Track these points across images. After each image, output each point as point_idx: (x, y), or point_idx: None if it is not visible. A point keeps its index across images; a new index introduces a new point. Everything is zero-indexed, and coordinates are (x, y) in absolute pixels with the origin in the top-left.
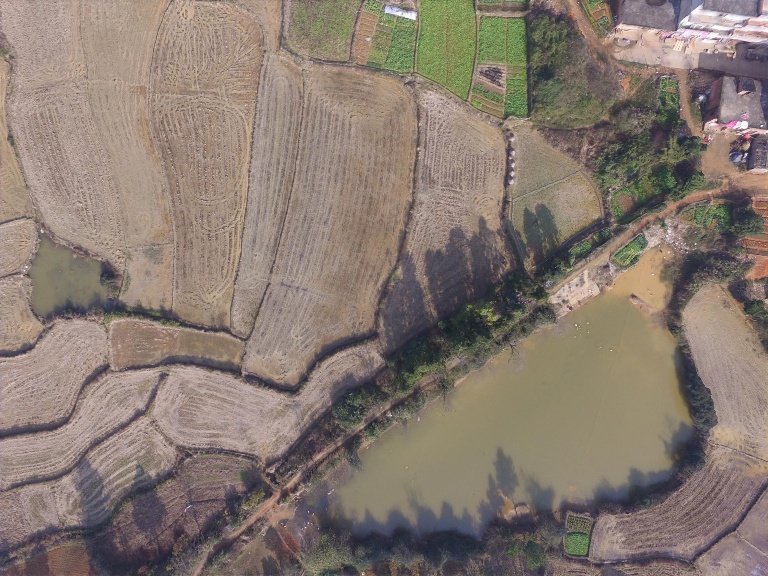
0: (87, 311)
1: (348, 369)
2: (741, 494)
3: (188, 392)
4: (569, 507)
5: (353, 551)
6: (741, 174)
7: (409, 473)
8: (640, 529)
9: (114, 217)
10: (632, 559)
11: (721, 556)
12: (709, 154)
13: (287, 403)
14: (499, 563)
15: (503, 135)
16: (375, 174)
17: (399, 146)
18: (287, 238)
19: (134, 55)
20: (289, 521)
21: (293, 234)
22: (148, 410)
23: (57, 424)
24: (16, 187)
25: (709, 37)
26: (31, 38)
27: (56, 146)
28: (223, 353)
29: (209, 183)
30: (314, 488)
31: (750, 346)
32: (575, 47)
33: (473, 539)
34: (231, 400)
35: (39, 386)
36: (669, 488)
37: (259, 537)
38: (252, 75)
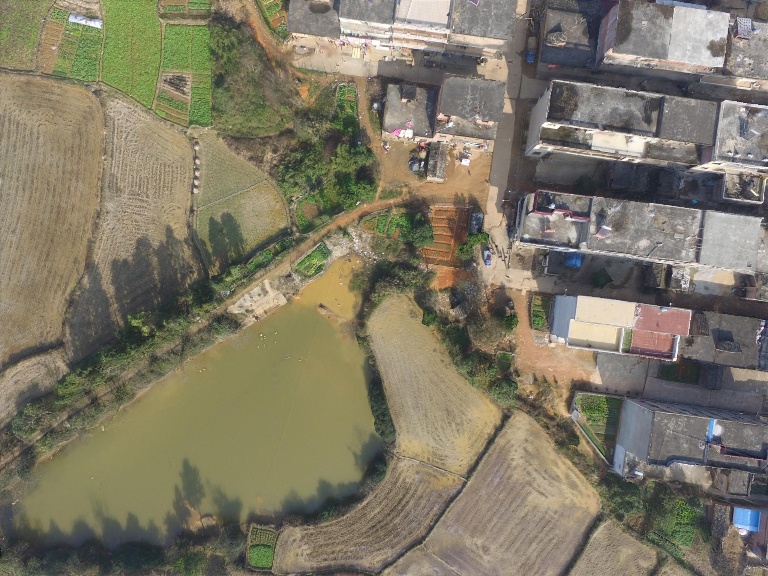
0: None
1: (34, 379)
2: (429, 507)
3: None
4: (254, 519)
5: (25, 562)
6: (421, 183)
7: (95, 483)
8: (325, 542)
9: None
10: (317, 572)
11: (408, 570)
12: (388, 162)
13: None
14: None
15: (190, 143)
16: (63, 183)
17: (87, 155)
18: None
19: None
20: None
21: None
22: None
23: None
24: None
25: (375, 45)
26: None
27: None
28: None
29: None
30: None
31: (438, 357)
32: (245, 55)
33: (159, 550)
34: None
35: None
36: (353, 500)
37: None
38: None
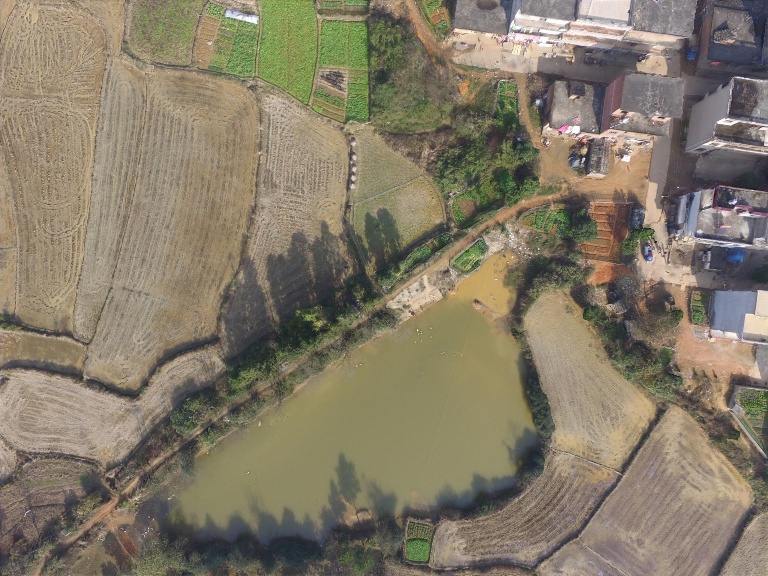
0: None
1: (189, 374)
2: (584, 501)
3: (29, 396)
4: (411, 513)
5: (187, 557)
6: (580, 179)
7: (250, 478)
8: (481, 536)
9: None
10: (473, 566)
11: (563, 563)
12: (548, 159)
13: (128, 408)
14: (339, 569)
15: (346, 139)
16: (218, 178)
17: (242, 150)
18: (129, 242)
19: None
20: (129, 526)
21: (135, 238)
22: None
23: None
24: None
25: (541, 41)
26: None
27: None
28: (65, 357)
29: (52, 187)
30: (154, 493)
31: (593, 352)
32: (409, 51)
33: (314, 545)
34: (72, 405)
35: None
36: (510, 494)
37: (98, 542)
38: (96, 79)
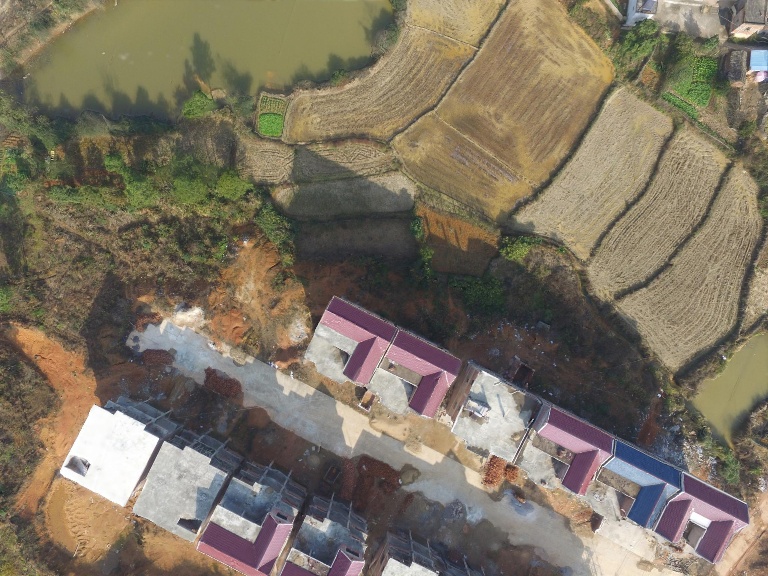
0: None
1: None
2: (440, 76)
3: None
4: (265, 90)
5: (34, 117)
6: None
7: (106, 59)
8: (335, 109)
9: None
10: (327, 140)
11: (419, 137)
12: None
13: None
14: (191, 143)
15: None
16: None
17: None
18: None
19: None
20: None
21: None
22: None
23: None
24: None
25: None
26: None
27: None
28: None
29: None
30: (10, 72)
31: None
32: None
33: (168, 124)
34: None
35: None
36: None
37: None
38: None
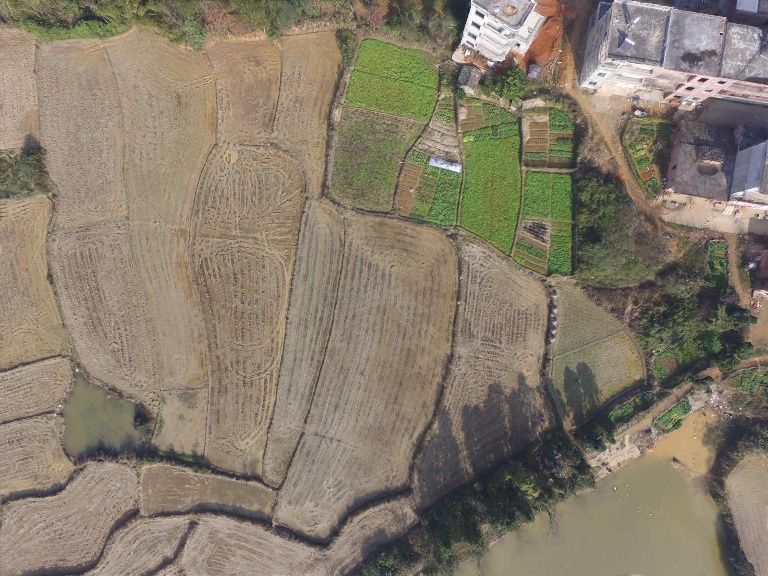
0: (119, 454)
1: (380, 524)
2: None
3: (217, 542)
4: None
5: None
6: None
7: None
8: None
9: (149, 359)
10: None
11: None
12: (757, 321)
13: (317, 557)
14: None
15: (545, 290)
16: (414, 325)
17: (439, 298)
18: (323, 387)
19: (176, 197)
20: None
21: (329, 384)
22: (177, 559)
23: (84, 567)
24: (53, 325)
25: (761, 208)
26: (74, 177)
27: (95, 286)
28: (254, 502)
29: (246, 328)
30: None
31: None
32: (623, 212)
33: None
34: (261, 552)
35: (68, 528)
36: None
37: None
38: (293, 221)
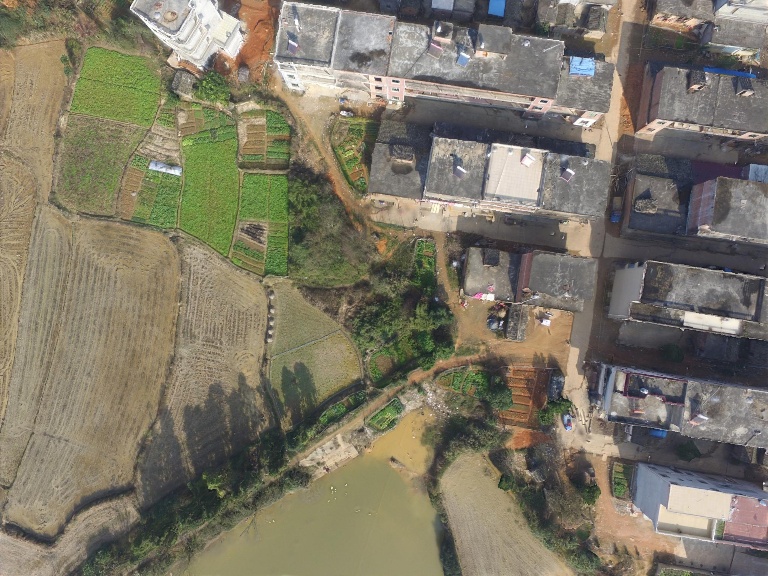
0: None
1: (104, 523)
2: None
3: None
4: None
5: None
6: (499, 341)
7: None
8: None
9: None
10: None
11: None
12: (466, 319)
13: (44, 554)
14: None
15: (265, 291)
16: (139, 327)
17: (163, 299)
18: (51, 388)
19: None
20: None
21: (57, 385)
22: None
23: None
24: None
25: None
26: None
27: None
28: None
29: None
30: None
31: (512, 517)
32: (324, 212)
33: None
34: None
35: None
36: None
37: None
38: (25, 226)
